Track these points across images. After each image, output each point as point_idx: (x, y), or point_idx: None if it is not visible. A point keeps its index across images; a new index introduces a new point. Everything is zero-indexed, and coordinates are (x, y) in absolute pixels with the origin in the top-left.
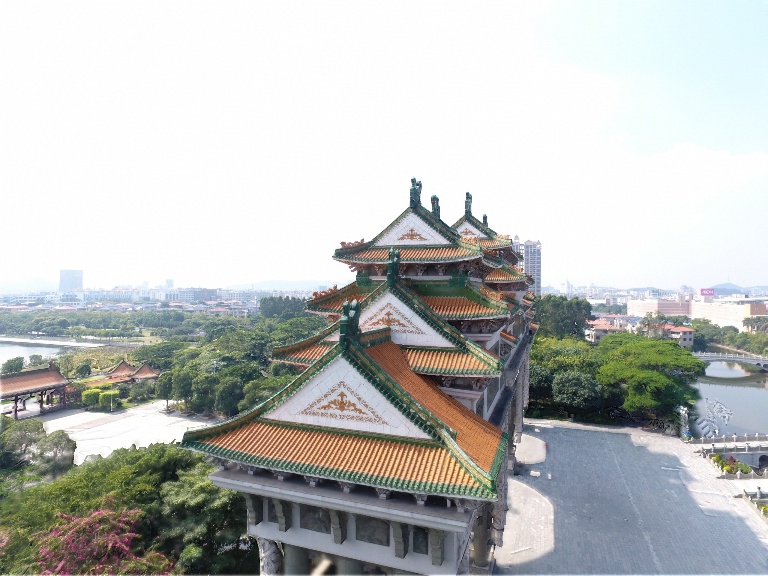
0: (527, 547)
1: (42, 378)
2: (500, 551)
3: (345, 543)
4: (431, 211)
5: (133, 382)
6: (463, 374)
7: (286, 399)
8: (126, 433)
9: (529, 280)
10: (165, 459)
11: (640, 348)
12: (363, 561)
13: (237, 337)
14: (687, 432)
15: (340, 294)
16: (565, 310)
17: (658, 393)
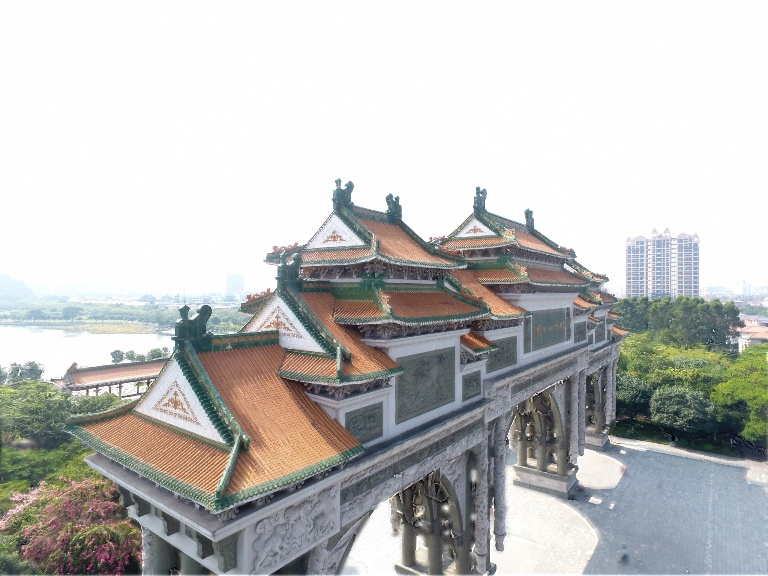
0: None
1: None
2: None
3: (176, 536)
4: (383, 211)
5: None
6: (313, 381)
7: (145, 394)
8: None
9: (583, 280)
10: None
11: None
12: (189, 556)
13: None
14: None
15: None
16: (699, 314)
17: None
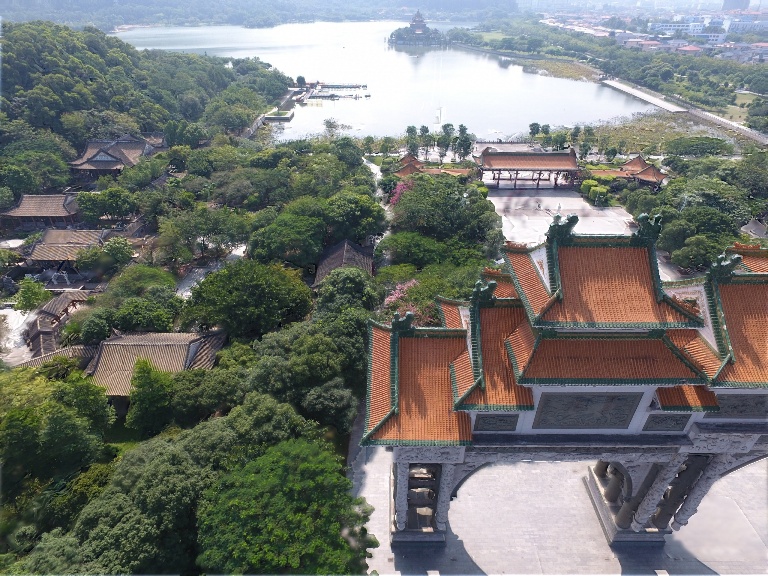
0: (724, 575)
1: (562, 161)
2: (690, 546)
3: None
4: None
5: (633, 181)
6: None
7: None
8: None
9: None
10: None
11: None
12: None
13: None
14: None
15: (501, 277)
16: None
17: None
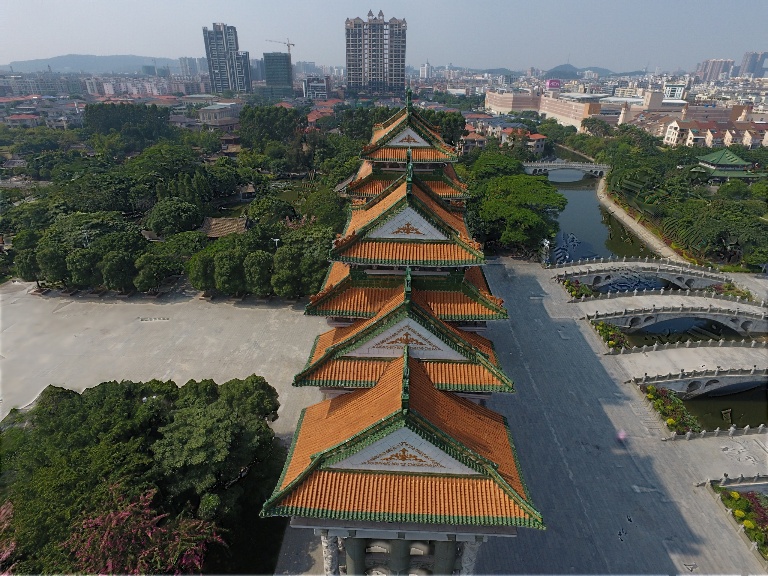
0: None
1: None
2: None
3: None
4: None
5: None
6: (482, 391)
7: (349, 455)
8: (6, 330)
9: None
10: (140, 420)
11: (518, 187)
12: None
13: (88, 183)
14: (547, 260)
15: (336, 291)
16: (444, 128)
17: (530, 229)
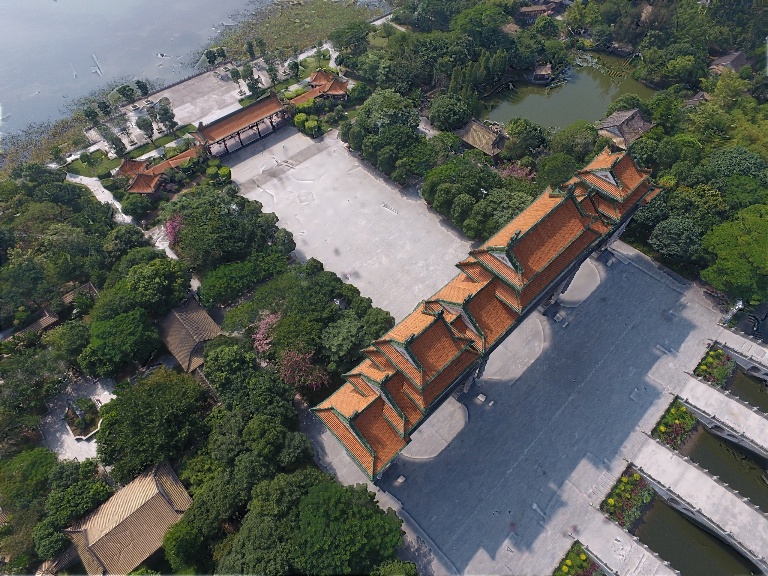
0: (499, 377)
1: (268, 105)
2: (484, 374)
3: None
4: (432, 321)
5: (328, 97)
6: None
7: None
8: (322, 177)
9: (596, 234)
10: (324, 316)
11: (765, 233)
12: None
13: (412, 47)
14: (726, 320)
15: None
16: None
17: (731, 284)
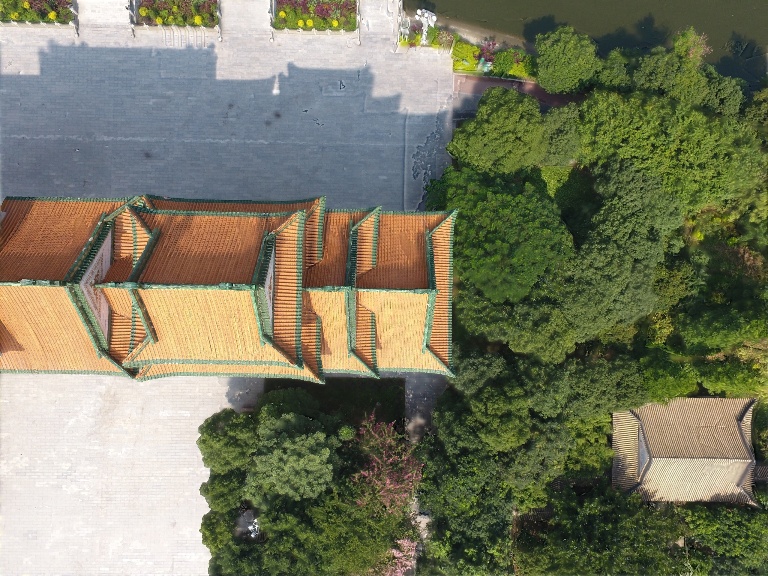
0: None
1: None
2: None
3: None
4: None
5: None
6: None
7: None
8: None
9: None
10: None
11: None
12: None
13: None
14: None
15: None
16: None
17: None
